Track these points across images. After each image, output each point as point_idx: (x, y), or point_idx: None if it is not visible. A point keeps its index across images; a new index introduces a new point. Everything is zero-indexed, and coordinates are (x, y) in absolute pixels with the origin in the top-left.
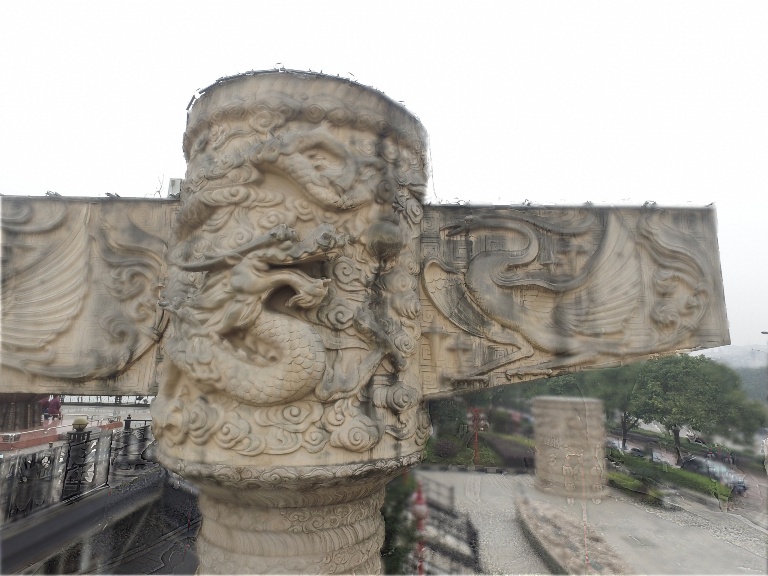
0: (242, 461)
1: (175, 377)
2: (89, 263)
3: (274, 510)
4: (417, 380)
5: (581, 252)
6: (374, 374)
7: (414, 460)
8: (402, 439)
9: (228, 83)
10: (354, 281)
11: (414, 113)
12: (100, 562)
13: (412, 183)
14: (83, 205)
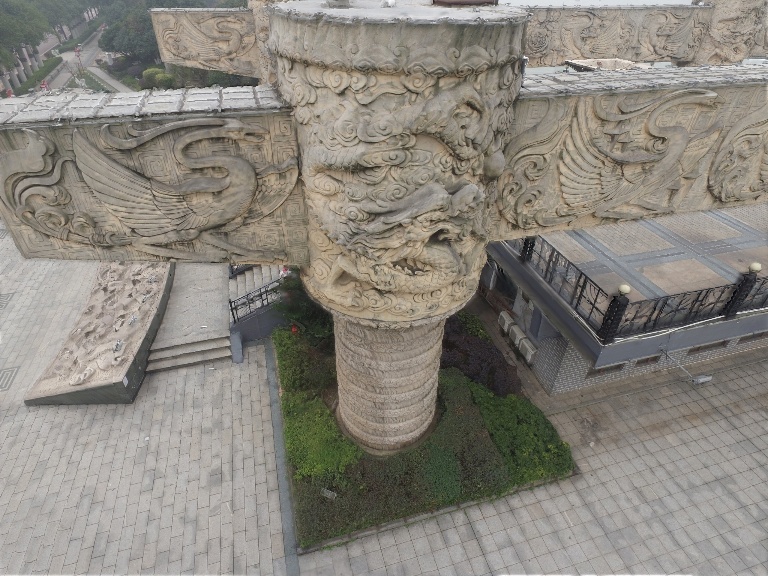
0: None
1: None
2: None
3: None
4: None
5: None
6: None
7: None
8: None
9: None
10: None
11: None
12: None
13: None
14: None
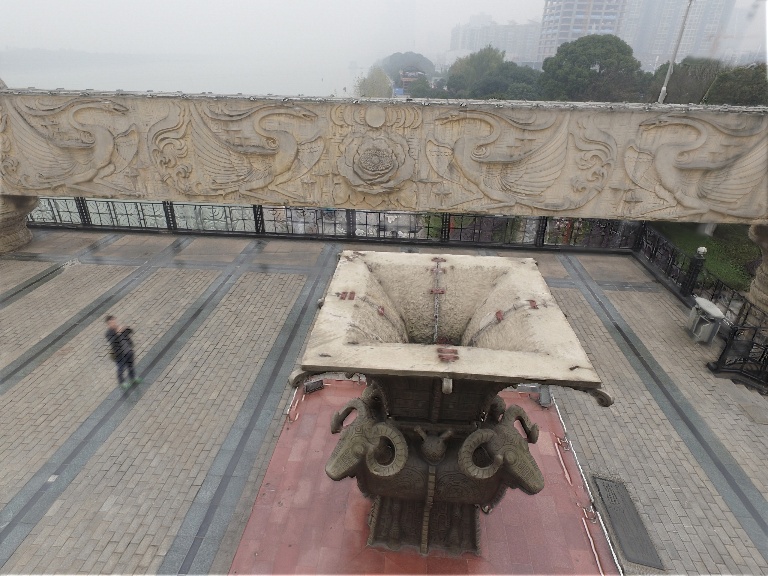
0: None
1: None
2: None
3: None
4: None
5: None
6: None
7: None
8: None
9: None
10: None
11: None
12: None
13: None
14: None
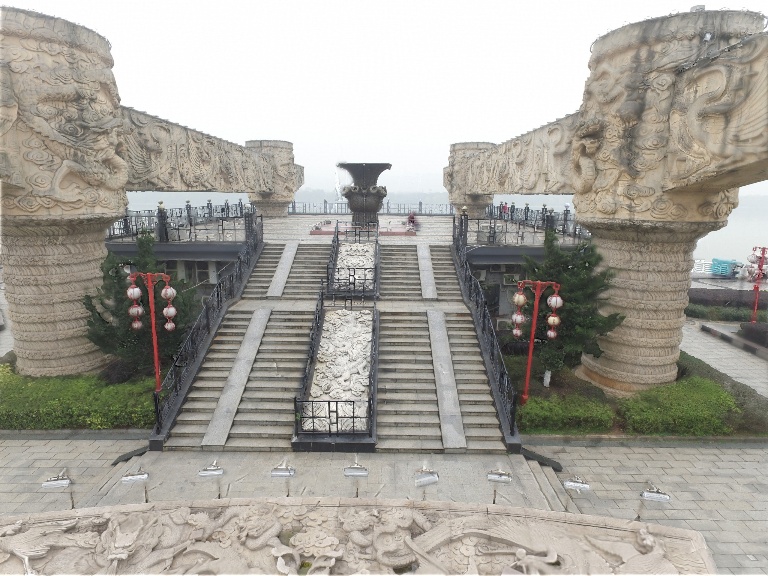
0: (577, 214)
1: None
2: None
3: None
4: (657, 183)
5: (753, 79)
6: (619, 180)
7: (647, 224)
8: (635, 212)
9: None
10: (614, 137)
11: (667, 16)
12: (712, 319)
13: (659, 67)
14: None
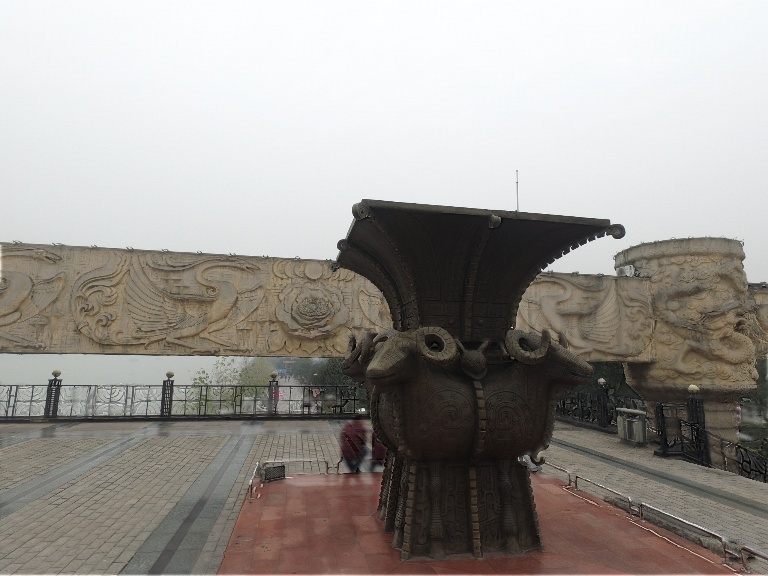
0: (730, 383)
1: (686, 355)
2: (619, 306)
3: (722, 403)
4: None
5: None
6: None
7: None
8: None
9: (696, 239)
10: None
11: None
12: None
13: None
14: (614, 281)
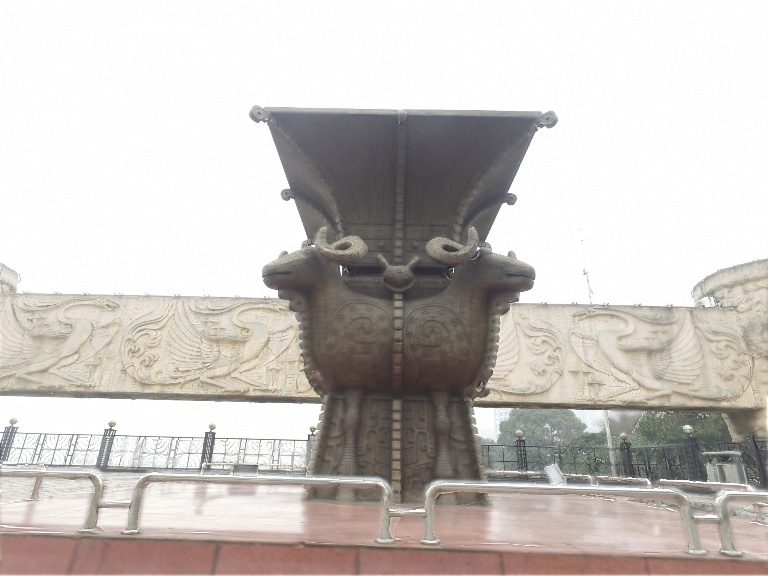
0: None
1: None
2: (700, 341)
3: None
4: None
5: None
6: None
7: None
8: None
9: None
10: None
11: None
12: None
13: None
14: (688, 312)
